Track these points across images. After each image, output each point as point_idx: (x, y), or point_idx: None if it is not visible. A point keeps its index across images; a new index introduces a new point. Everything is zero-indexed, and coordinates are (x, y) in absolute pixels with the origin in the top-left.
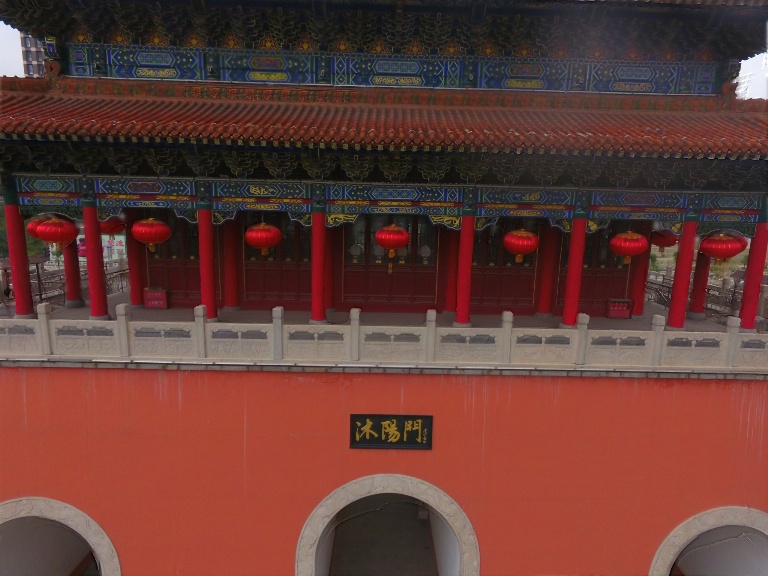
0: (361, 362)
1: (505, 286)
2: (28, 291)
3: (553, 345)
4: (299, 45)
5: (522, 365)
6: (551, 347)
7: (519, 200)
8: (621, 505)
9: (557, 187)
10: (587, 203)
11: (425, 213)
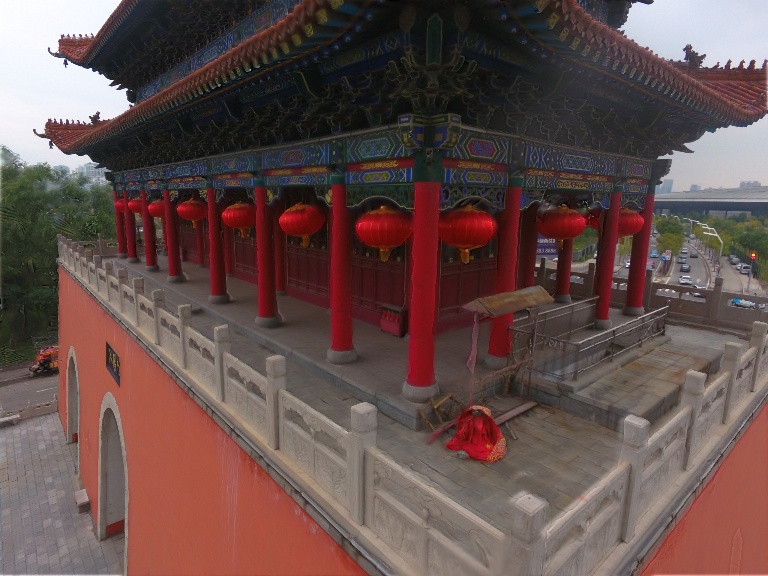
0: (107, 302)
1: (312, 270)
2: (123, 240)
3: (150, 318)
4: (185, 57)
5: (136, 330)
6: (149, 319)
7: (227, 169)
8: (167, 518)
9: (241, 151)
10: (259, 167)
11: (195, 187)
